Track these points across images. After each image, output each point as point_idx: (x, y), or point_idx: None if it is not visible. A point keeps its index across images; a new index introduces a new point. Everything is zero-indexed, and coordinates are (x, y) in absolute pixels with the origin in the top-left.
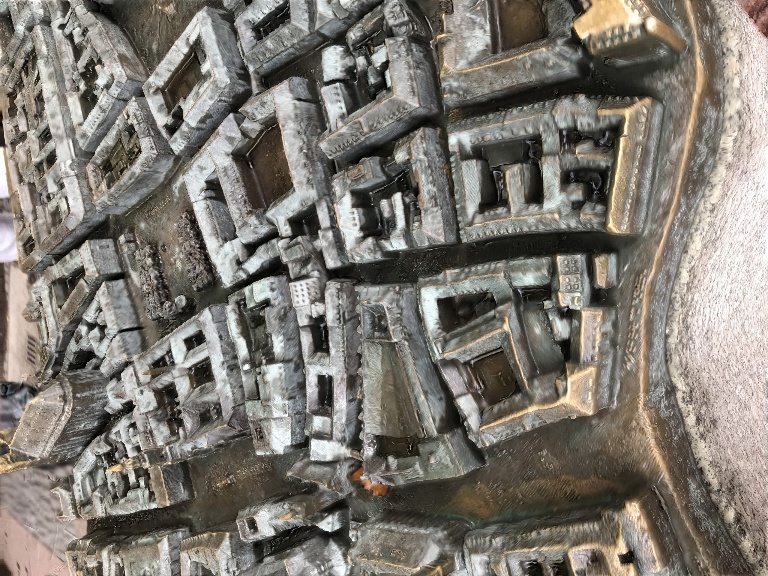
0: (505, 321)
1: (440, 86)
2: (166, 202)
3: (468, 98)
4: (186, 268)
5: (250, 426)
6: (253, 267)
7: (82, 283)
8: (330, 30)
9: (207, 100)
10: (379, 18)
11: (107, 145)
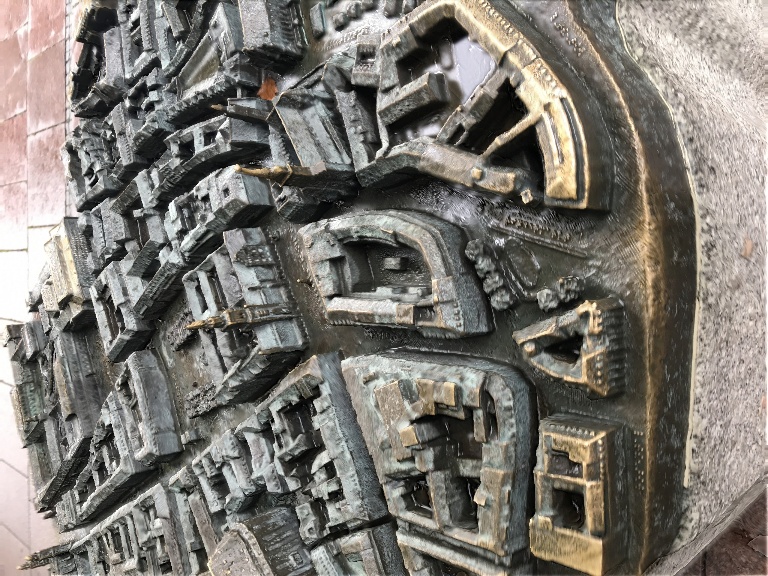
0: (161, 5)
1: (118, 93)
2: (175, 378)
3: (123, 77)
4: (188, 333)
5: (224, 205)
6: (173, 232)
7: (191, 500)
8: (112, 185)
9: (114, 281)
10: (103, 141)
11: (130, 425)
